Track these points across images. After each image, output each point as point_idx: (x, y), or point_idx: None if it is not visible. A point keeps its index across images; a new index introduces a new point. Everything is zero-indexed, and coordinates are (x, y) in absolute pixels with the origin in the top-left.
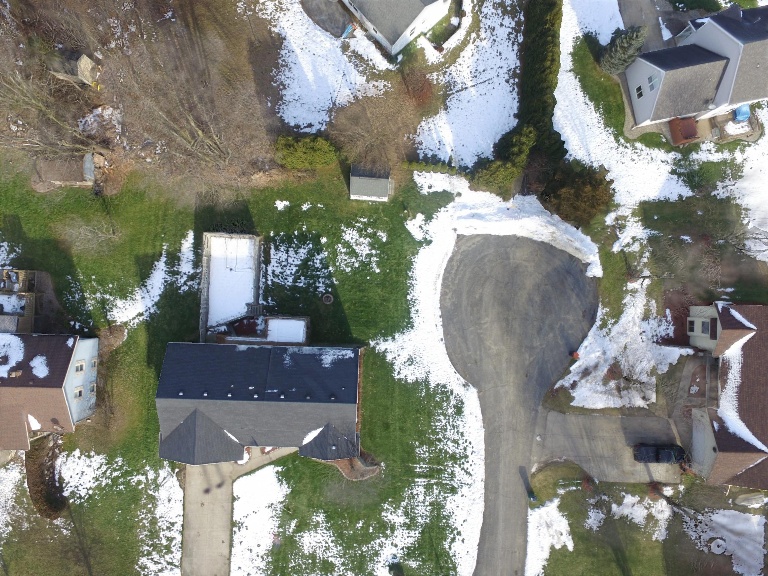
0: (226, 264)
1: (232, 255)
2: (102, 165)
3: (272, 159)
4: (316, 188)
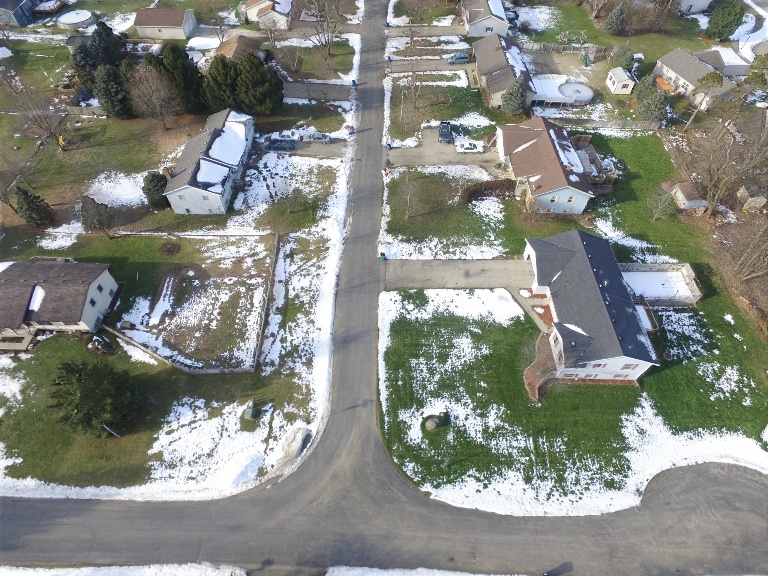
0: None
1: (674, 285)
2: (697, 213)
3: (763, 310)
4: (759, 343)
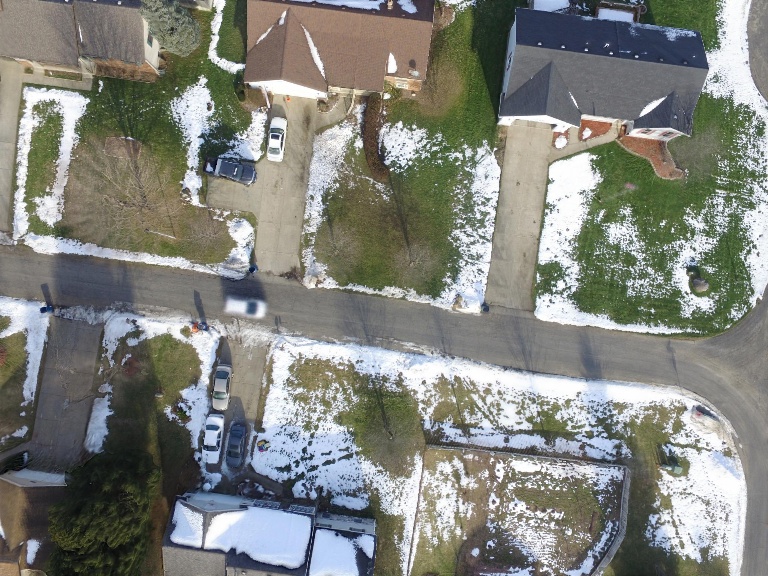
0: None
1: None
2: None
3: None
4: None
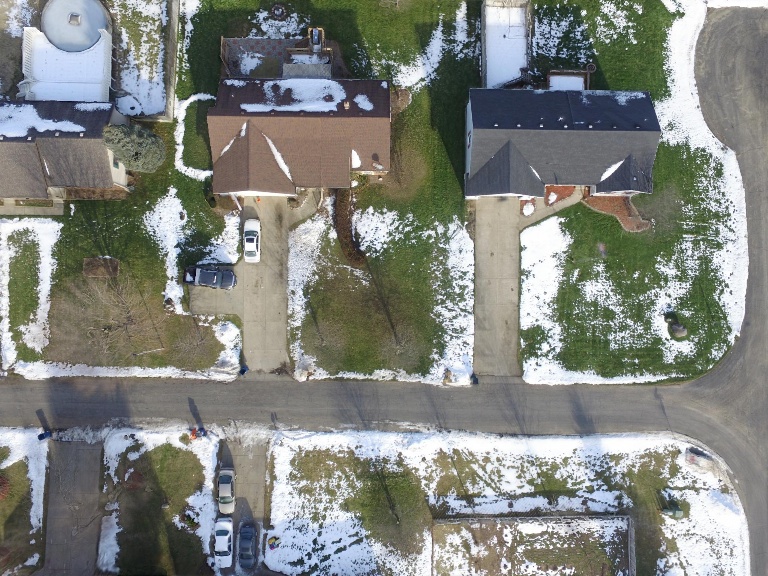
0: (509, 23)
1: (505, 23)
2: None
3: None
4: None
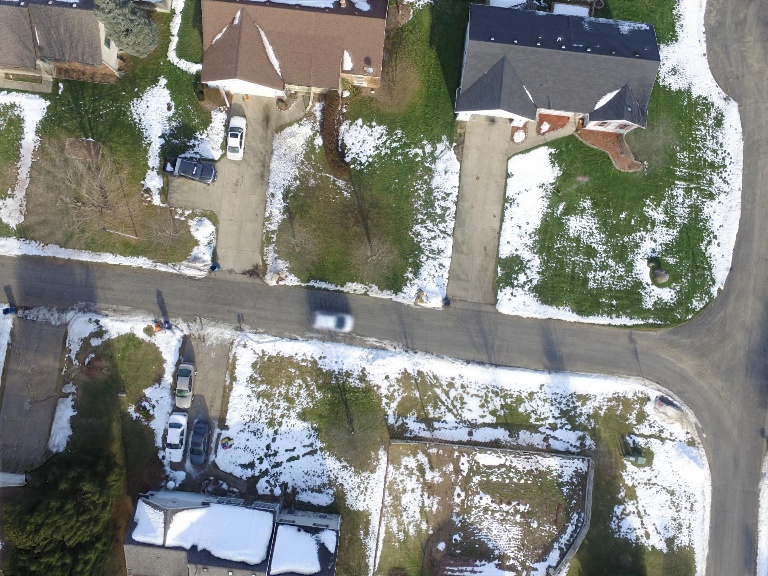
0: None
1: None
2: None
3: None
4: None
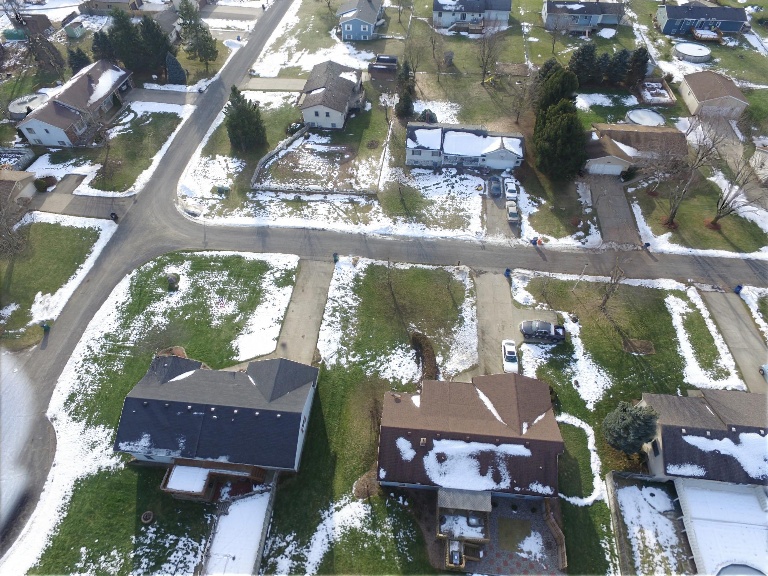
0: None
1: None
2: None
3: None
4: None
